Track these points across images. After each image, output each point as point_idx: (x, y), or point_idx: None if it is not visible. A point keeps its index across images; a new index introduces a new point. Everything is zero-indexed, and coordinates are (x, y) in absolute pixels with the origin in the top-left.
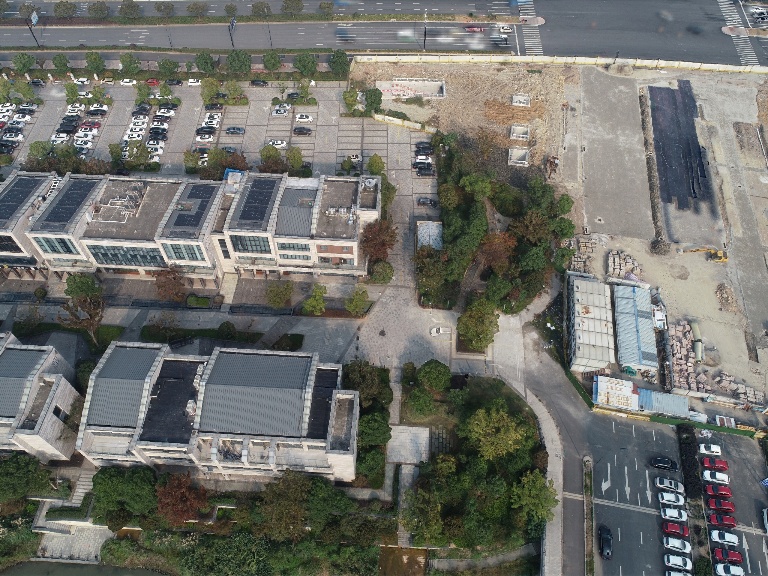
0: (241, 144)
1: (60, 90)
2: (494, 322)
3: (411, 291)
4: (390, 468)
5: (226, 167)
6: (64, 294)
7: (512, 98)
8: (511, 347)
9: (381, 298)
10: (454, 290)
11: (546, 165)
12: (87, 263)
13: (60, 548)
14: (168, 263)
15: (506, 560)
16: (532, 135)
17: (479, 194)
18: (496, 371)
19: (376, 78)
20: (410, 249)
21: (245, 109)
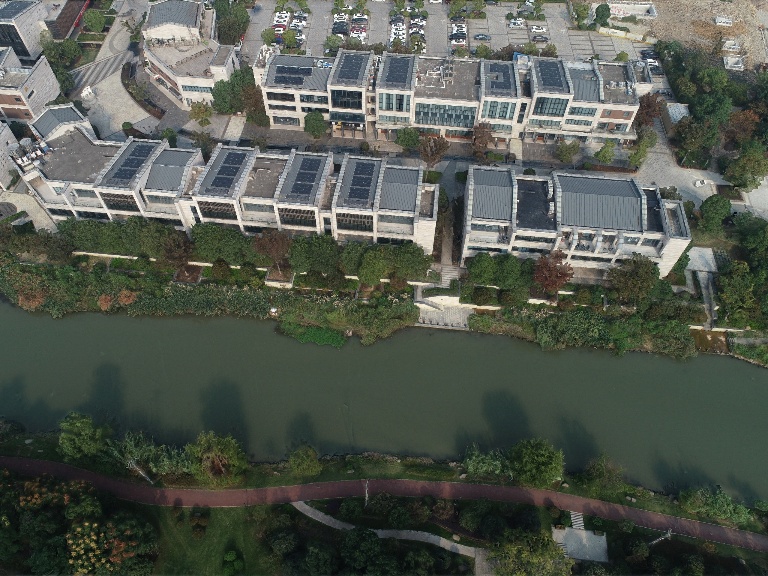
0: (490, 48)
1: (321, 3)
2: (767, 165)
3: (669, 156)
4: (688, 273)
5: (507, 54)
6: (383, 149)
7: (715, 19)
8: (764, 197)
9: (645, 160)
10: (707, 155)
11: (759, 70)
12: (405, 123)
13: (435, 319)
14: (479, 121)
15: None
16: (740, 47)
17: (718, 83)
18: (756, 213)
19: (590, 1)
20: (659, 127)
21: (484, 22)
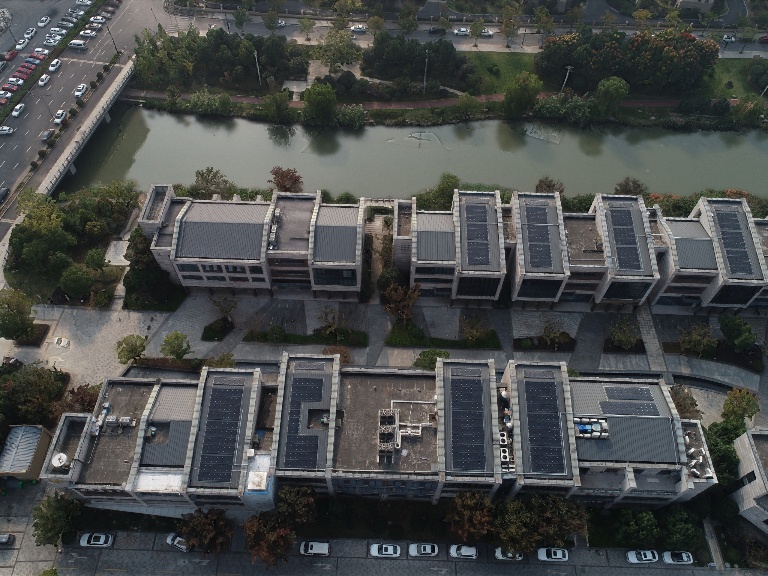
0: None
1: None
2: None
3: None
4: None
5: (278, 523)
6: None
7: None
8: None
9: None
10: None
11: None
12: None
13: None
14: None
15: (78, 200)
16: None
17: None
18: None
19: None
20: None
21: None
